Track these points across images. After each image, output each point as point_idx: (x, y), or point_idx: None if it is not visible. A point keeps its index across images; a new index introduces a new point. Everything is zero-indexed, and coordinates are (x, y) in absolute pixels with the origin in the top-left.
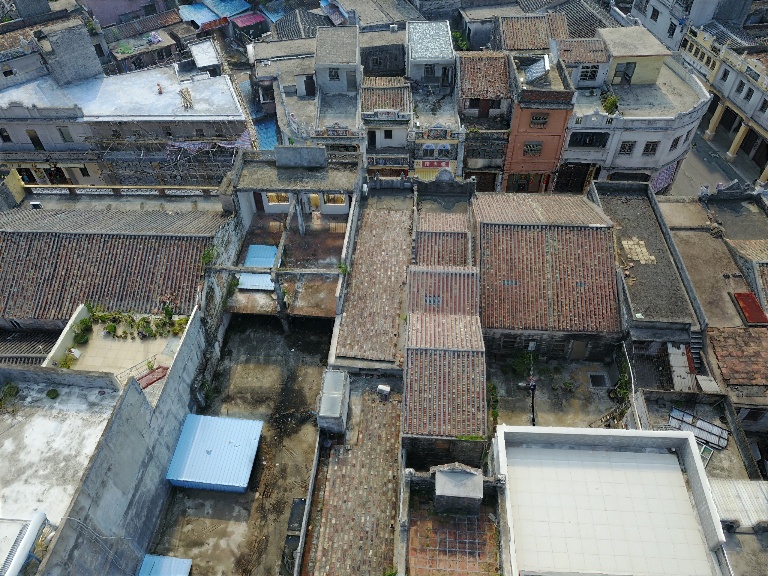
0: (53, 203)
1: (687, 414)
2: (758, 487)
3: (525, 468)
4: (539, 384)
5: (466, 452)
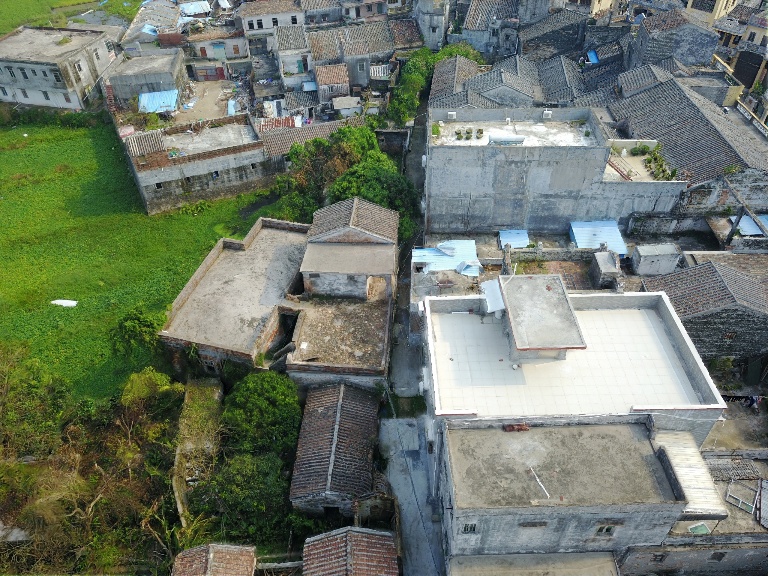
0: (735, 117)
1: None
2: (709, 487)
3: (642, 319)
4: (766, 423)
5: None
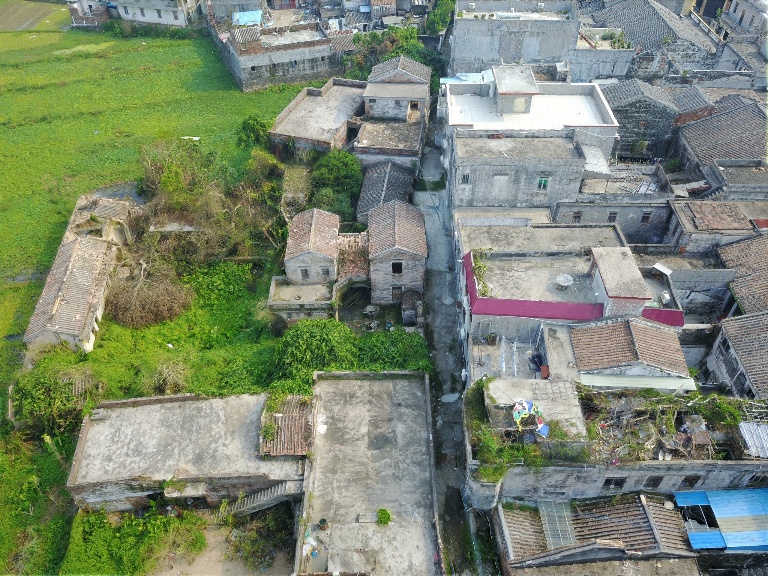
0: (688, 22)
1: (655, 188)
2: (604, 165)
3: (582, 99)
4: None
5: None
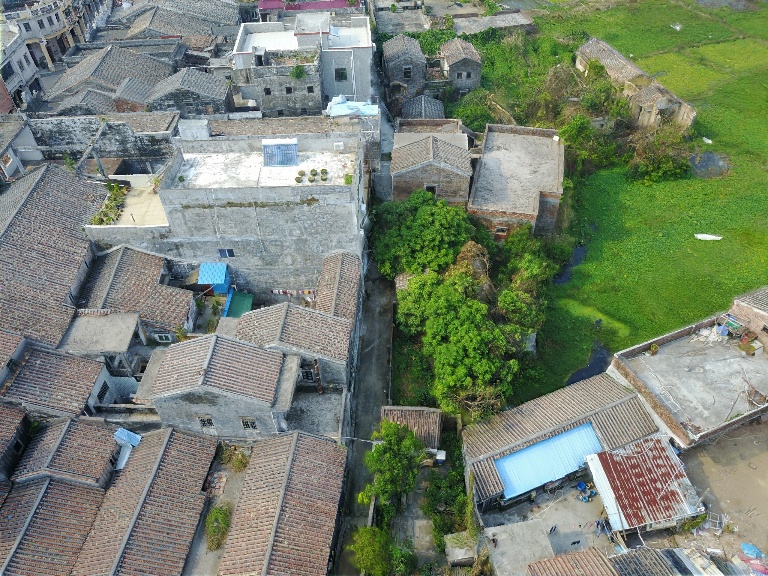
0: None
1: (221, 56)
2: None
3: None
4: None
5: (231, 99)
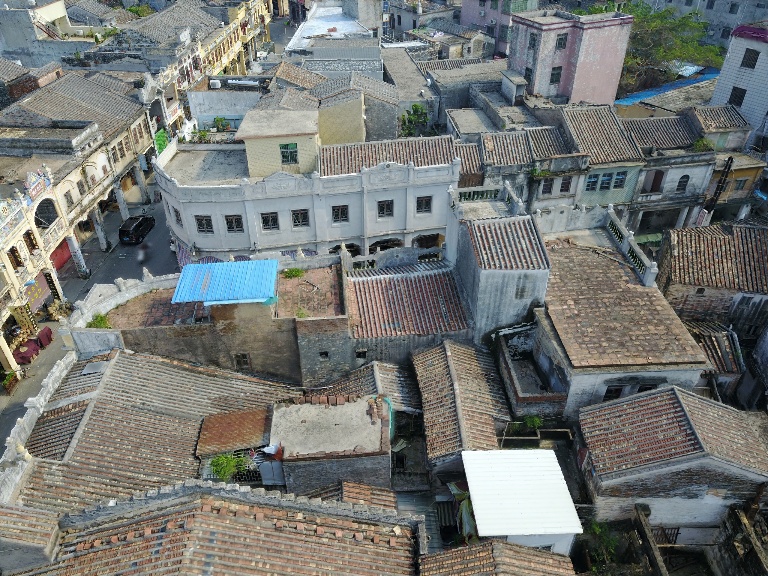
0: None
1: None
2: None
3: None
4: None
5: None
